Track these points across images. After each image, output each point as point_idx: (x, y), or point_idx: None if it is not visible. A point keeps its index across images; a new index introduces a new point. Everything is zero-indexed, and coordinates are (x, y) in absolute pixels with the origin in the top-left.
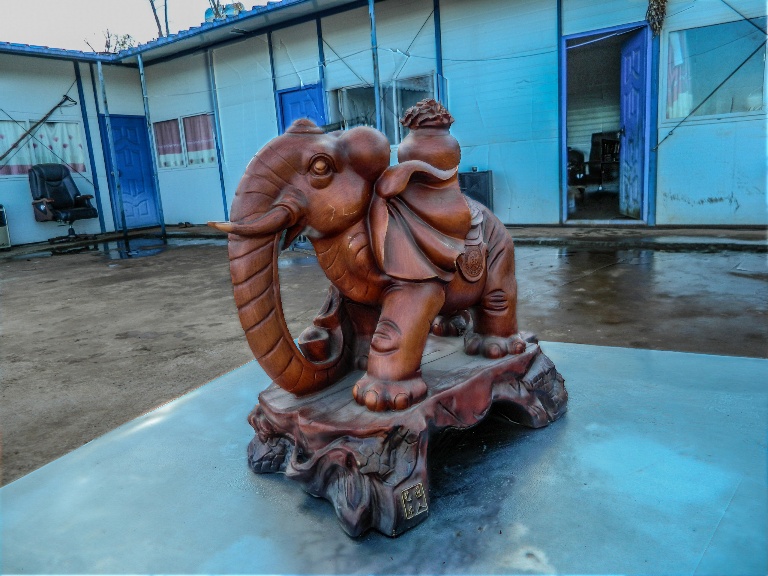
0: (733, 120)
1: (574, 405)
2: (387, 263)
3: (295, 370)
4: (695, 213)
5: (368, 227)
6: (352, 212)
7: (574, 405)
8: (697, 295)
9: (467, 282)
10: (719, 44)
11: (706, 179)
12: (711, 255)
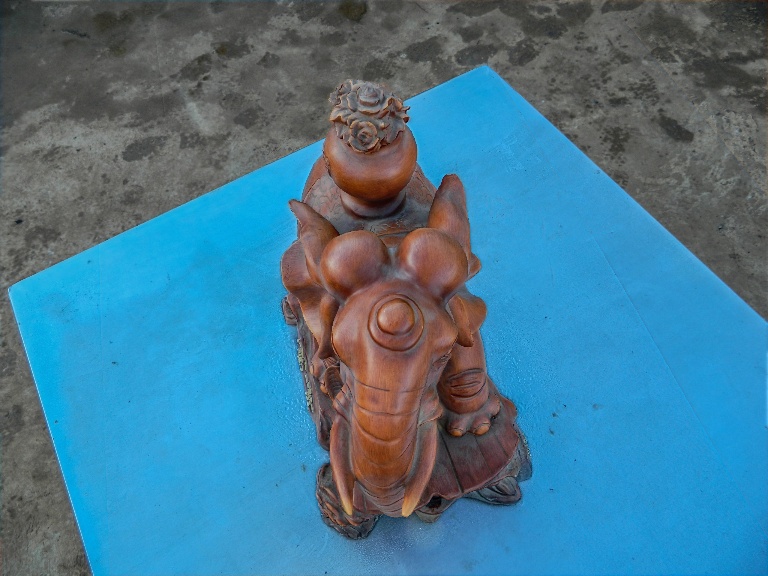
0: None
1: None
2: None
3: None
4: None
5: None
6: None
7: None
8: None
9: None
10: None
11: None
12: None
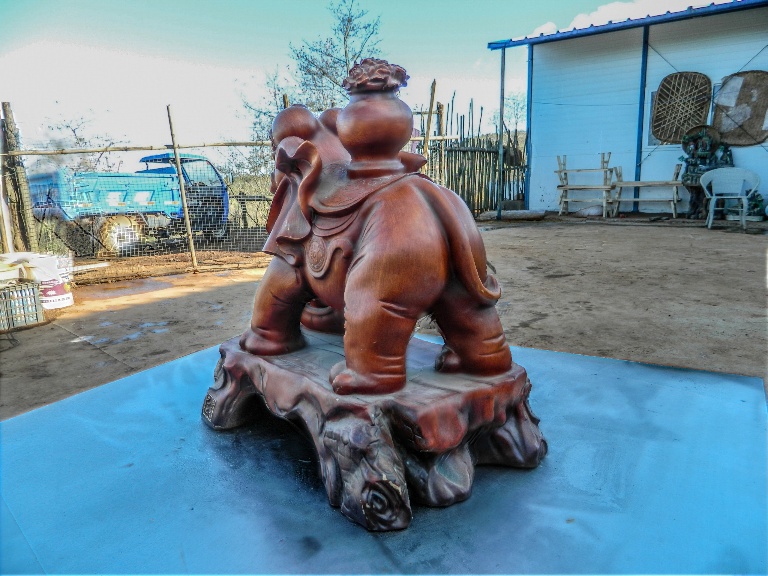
0: None
1: (387, 542)
2: None
3: None
4: None
5: None
6: (276, 182)
7: (387, 542)
8: None
9: None
10: None
11: None
12: None
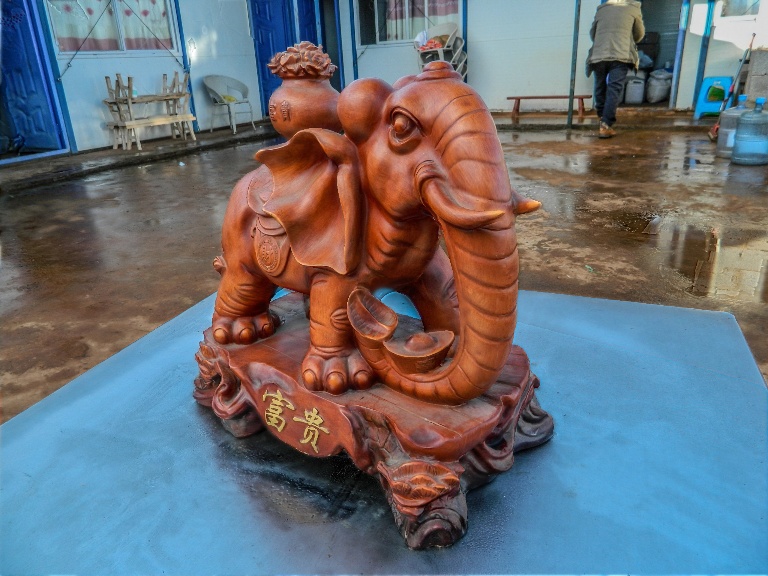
0: None
1: None
2: None
3: None
4: None
5: None
6: None
7: None
8: None
9: None
10: None
11: None
12: None
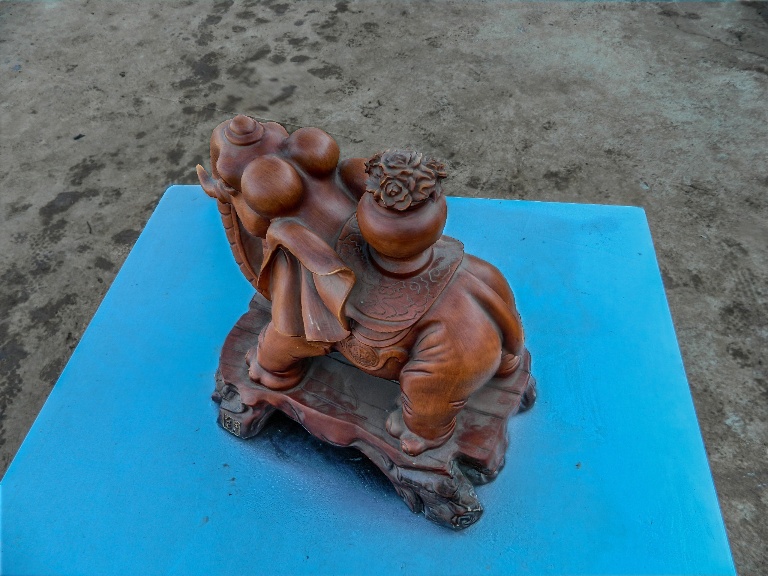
0: None
1: (475, 538)
2: (272, 289)
3: None
4: None
5: None
6: None
7: (475, 538)
8: None
9: None
10: None
11: None
12: None
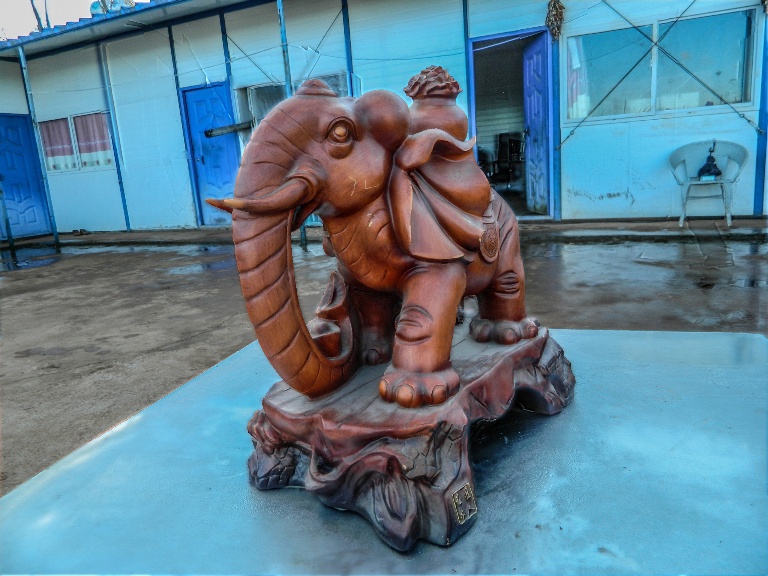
0: (626, 120)
1: (578, 389)
2: (412, 242)
3: (312, 368)
4: (596, 208)
5: (388, 203)
6: (374, 185)
7: (578, 389)
8: (612, 283)
9: (485, 263)
10: (611, 50)
11: (605, 176)
12: (616, 246)
